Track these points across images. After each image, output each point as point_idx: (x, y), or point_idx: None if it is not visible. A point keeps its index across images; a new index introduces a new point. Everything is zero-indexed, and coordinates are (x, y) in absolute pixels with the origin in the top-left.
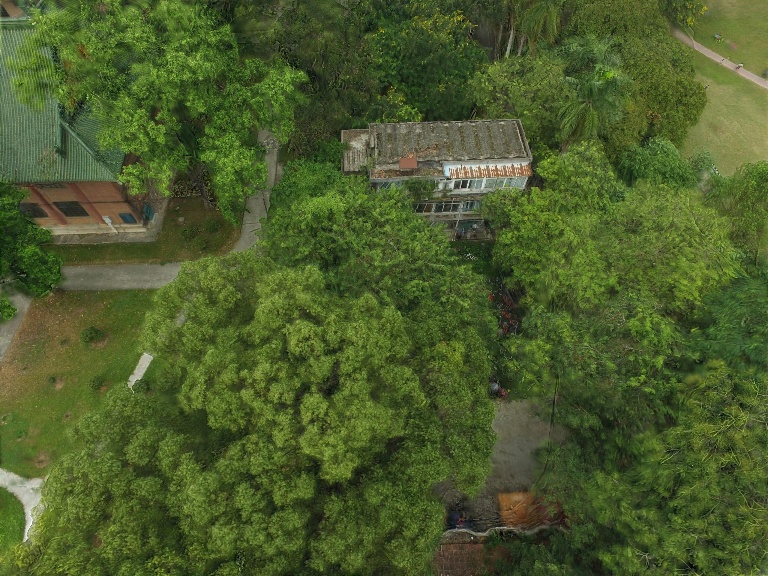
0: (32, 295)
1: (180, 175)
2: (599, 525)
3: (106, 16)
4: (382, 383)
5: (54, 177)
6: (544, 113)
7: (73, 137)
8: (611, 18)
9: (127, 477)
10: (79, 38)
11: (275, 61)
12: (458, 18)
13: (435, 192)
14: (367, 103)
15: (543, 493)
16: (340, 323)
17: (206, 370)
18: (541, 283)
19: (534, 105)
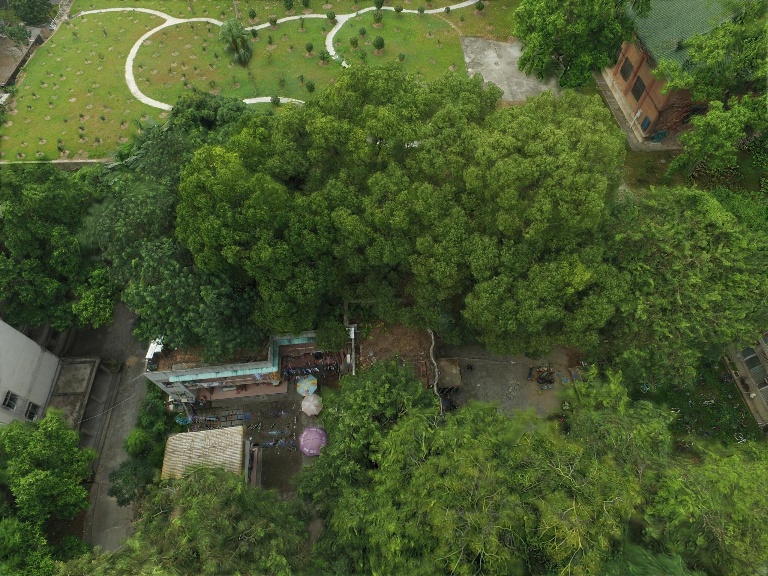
0: None
1: None
2: None
3: None
4: (535, 197)
5: (656, 54)
6: None
7: None
8: None
9: (452, 95)
10: None
11: None
12: None
13: None
14: None
15: None
16: None
17: None
18: None
19: None
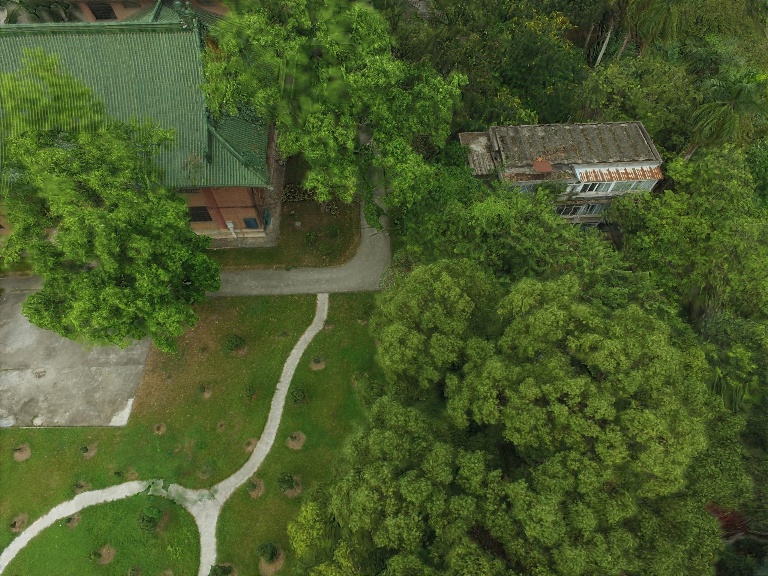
0: None
1: (289, 179)
2: None
3: (288, 19)
4: None
5: (200, 182)
6: (669, 115)
7: (219, 142)
8: (704, 19)
9: (442, 496)
10: (221, 41)
11: (425, 64)
12: (559, 19)
13: (561, 195)
14: (482, 105)
15: None
16: (625, 335)
17: (492, 384)
18: (691, 288)
19: (658, 107)
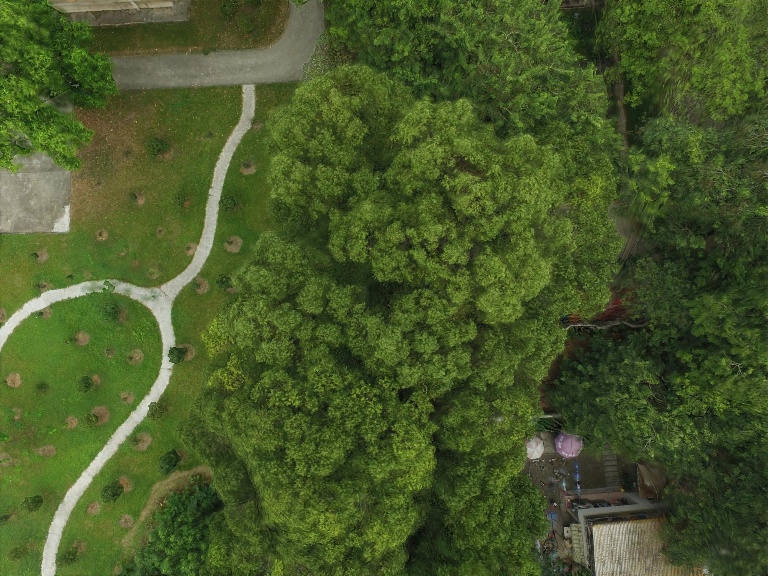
0: (70, 97)
1: None
2: (684, 332)
3: None
4: (542, 235)
5: None
6: None
7: None
8: None
9: (310, 325)
10: None
11: None
12: None
13: None
14: None
15: (620, 296)
16: (504, 174)
17: (364, 225)
18: (657, 79)
19: None
